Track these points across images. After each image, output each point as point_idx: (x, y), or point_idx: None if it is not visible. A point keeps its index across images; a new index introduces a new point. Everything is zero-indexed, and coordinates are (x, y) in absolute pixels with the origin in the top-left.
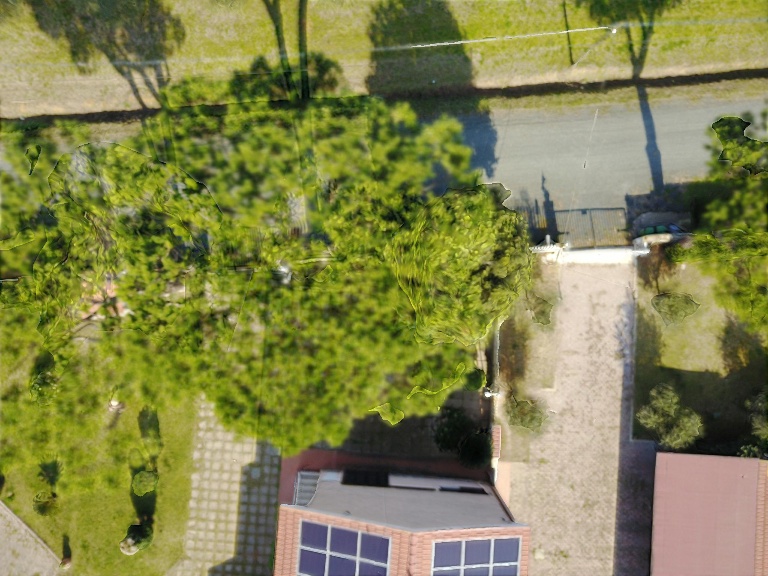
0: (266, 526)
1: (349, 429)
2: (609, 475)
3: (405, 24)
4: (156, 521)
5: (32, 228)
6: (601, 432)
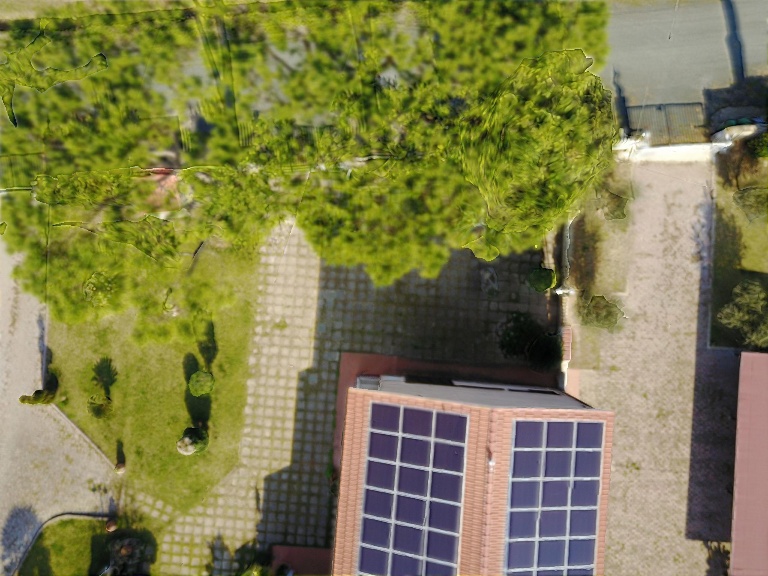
0: (324, 434)
1: (410, 334)
2: (685, 384)
3: None
4: (211, 427)
5: (85, 128)
6: (676, 339)
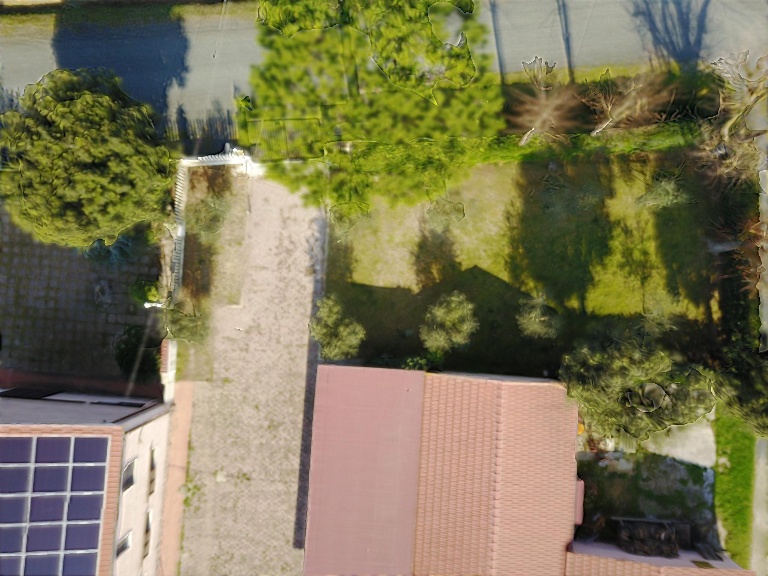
0: None
1: (27, 347)
2: (296, 395)
3: None
4: None
5: None
6: (288, 350)
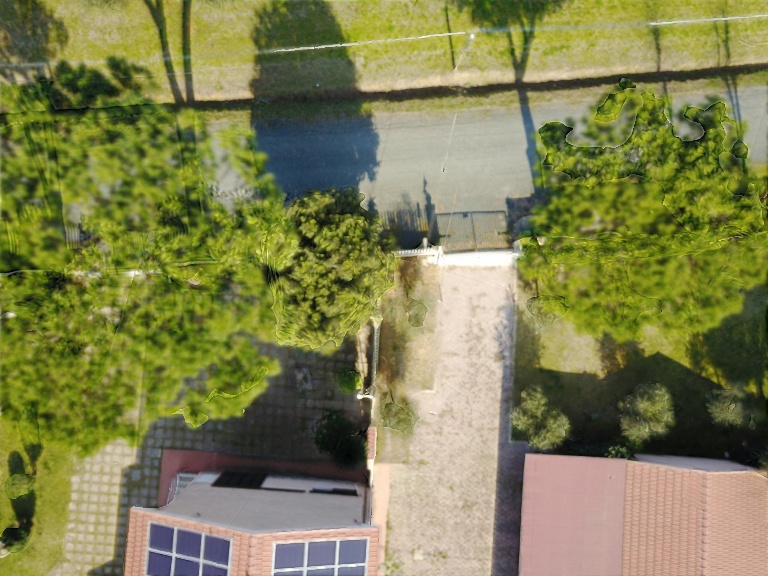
0: None
1: (230, 431)
2: (488, 476)
3: (289, 28)
4: (35, 524)
5: None
6: (480, 433)
